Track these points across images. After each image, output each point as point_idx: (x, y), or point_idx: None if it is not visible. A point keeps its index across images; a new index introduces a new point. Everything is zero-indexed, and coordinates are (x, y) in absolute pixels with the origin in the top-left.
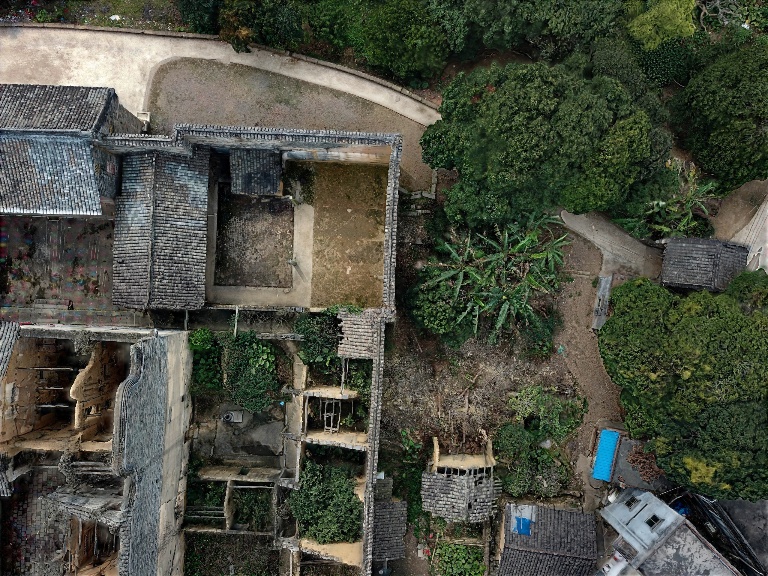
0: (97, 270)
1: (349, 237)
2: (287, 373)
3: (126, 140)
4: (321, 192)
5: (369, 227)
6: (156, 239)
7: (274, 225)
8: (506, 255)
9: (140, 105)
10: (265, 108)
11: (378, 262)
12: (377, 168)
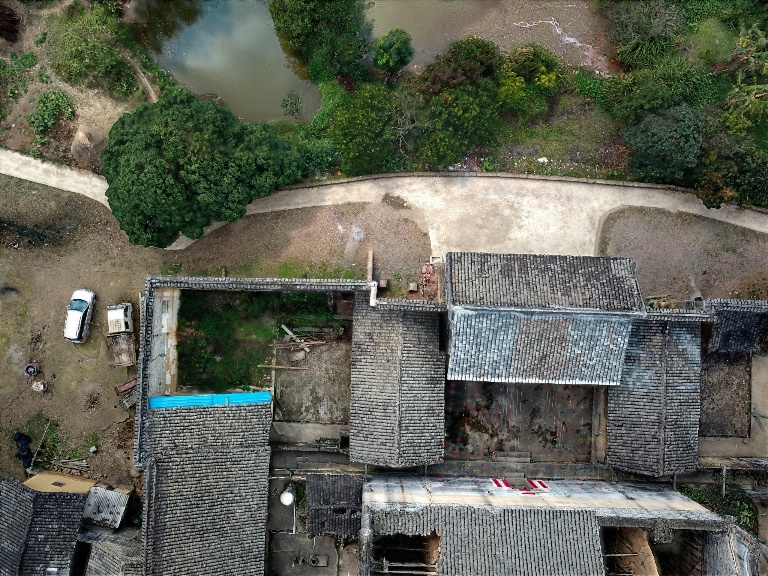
0: (555, 421)
1: None
2: (754, 525)
3: (663, 316)
4: None
5: None
6: (666, 406)
7: (730, 375)
8: None
9: (591, 254)
10: (713, 256)
11: None
12: None
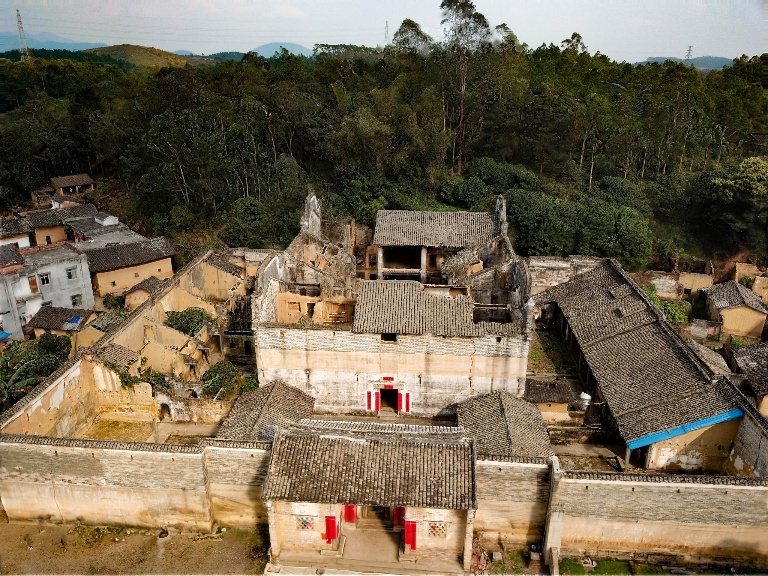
0: None
1: None
2: None
3: None
4: None
5: None
6: None
7: None
8: None
9: None
10: None
11: None
12: None
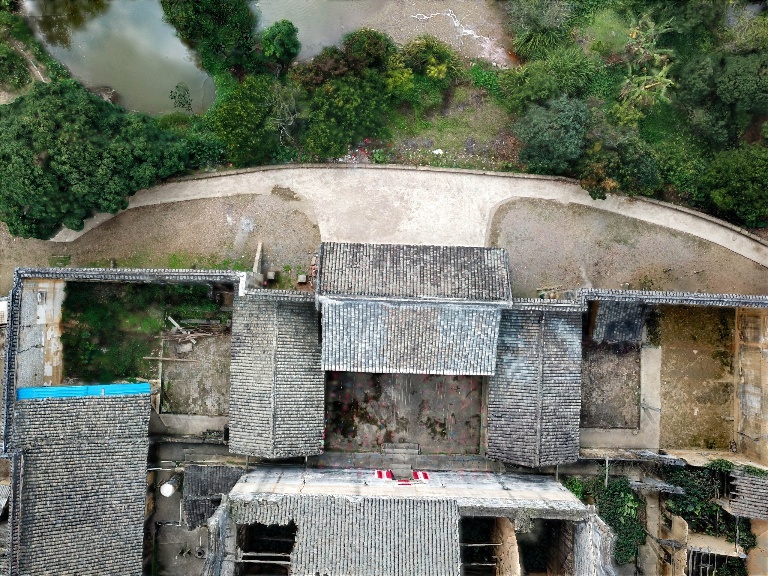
0: (444, 413)
1: (696, 378)
2: (642, 516)
3: (533, 306)
4: (668, 334)
5: (715, 368)
6: (543, 396)
7: (620, 366)
8: None
9: (481, 246)
10: (604, 248)
11: (725, 403)
12: (723, 309)
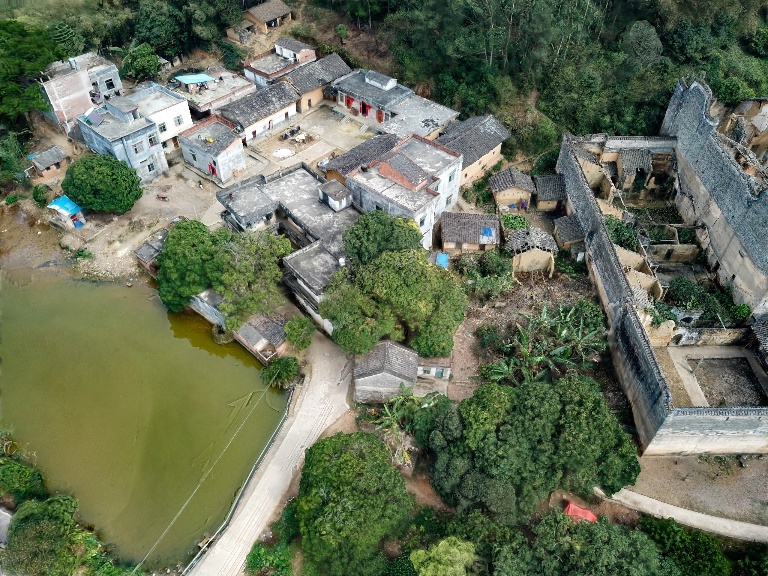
0: None
1: None
2: None
3: None
4: None
5: None
6: None
7: None
8: (547, 356)
9: None
10: None
11: None
12: None
